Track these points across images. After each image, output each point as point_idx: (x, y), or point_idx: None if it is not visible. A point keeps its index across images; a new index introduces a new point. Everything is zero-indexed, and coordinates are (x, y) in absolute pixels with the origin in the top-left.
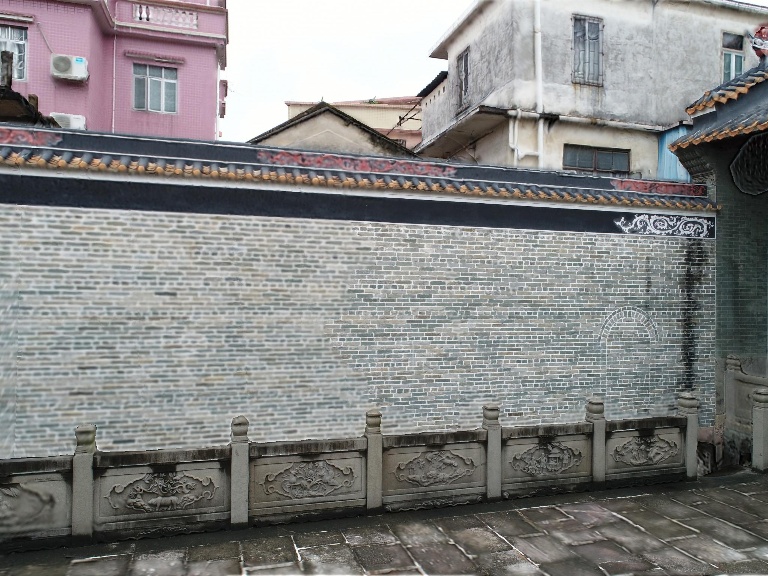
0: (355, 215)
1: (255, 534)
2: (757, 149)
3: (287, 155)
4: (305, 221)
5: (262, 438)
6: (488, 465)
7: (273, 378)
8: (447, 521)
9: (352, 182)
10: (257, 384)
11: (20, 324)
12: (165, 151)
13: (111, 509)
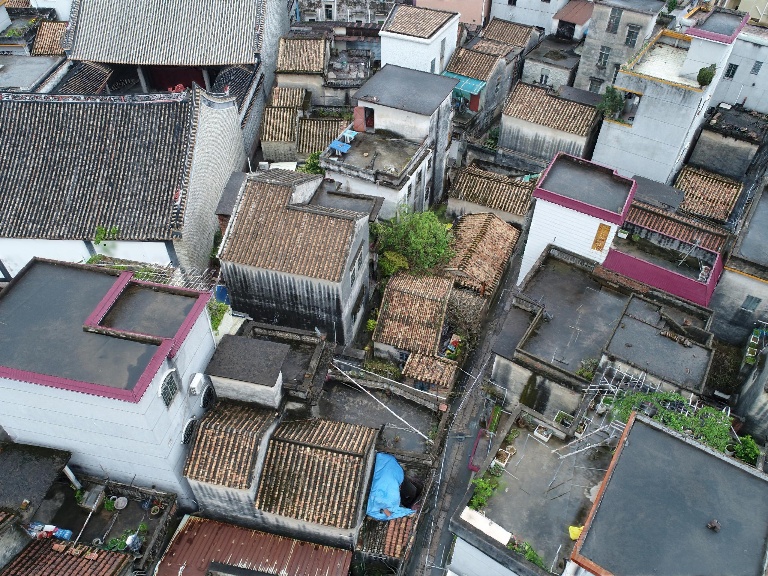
0: None
1: None
2: (284, 5)
3: None
4: None
5: None
6: None
7: None
8: None
9: None
10: None
11: None
12: None
13: None
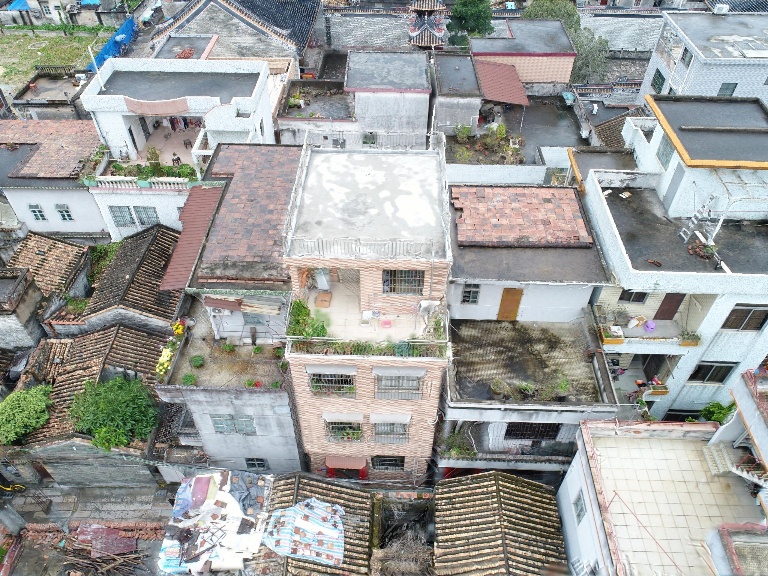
0: (641, 17)
1: (621, 59)
2: None
3: (634, 8)
4: (634, 18)
5: (620, 47)
6: (648, 55)
7: (623, 39)
8: (641, 61)
9: (642, 12)
10: (621, 40)
11: (596, 31)
12: (618, 8)
13: (609, 55)
